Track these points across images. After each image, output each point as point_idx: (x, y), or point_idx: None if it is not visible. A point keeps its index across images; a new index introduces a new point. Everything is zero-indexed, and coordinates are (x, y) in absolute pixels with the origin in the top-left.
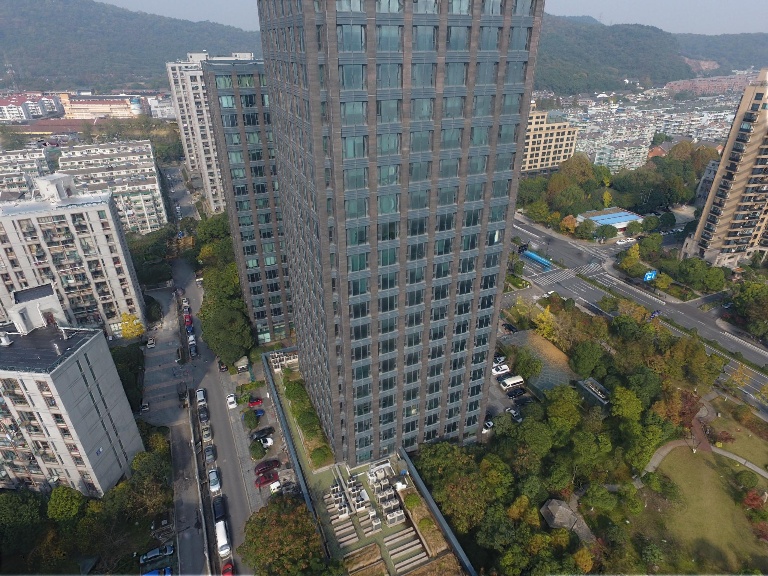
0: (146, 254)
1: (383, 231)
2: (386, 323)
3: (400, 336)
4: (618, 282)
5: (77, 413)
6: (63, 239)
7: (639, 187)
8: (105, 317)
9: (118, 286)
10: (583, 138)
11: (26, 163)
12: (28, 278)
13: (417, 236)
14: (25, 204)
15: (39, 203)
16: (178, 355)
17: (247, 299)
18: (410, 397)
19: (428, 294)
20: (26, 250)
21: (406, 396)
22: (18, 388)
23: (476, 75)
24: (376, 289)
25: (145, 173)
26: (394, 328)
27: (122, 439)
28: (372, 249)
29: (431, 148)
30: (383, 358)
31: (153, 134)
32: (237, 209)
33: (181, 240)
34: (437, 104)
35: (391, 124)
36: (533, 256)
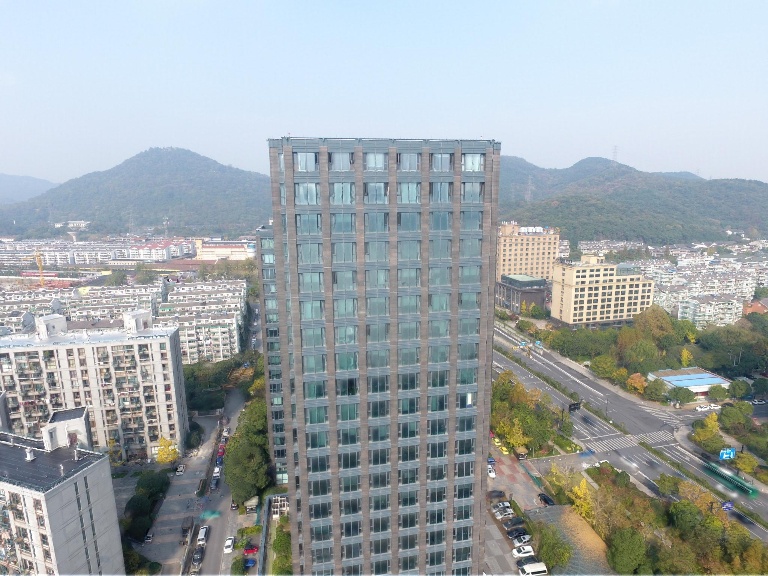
0: (210, 381)
1: (342, 386)
2: (348, 481)
3: (364, 497)
4: (692, 457)
5: (62, 536)
6: (128, 365)
7: (727, 346)
8: (148, 440)
9: (165, 411)
10: (664, 290)
11: (144, 296)
12: (93, 397)
13: (378, 393)
14: (109, 334)
15: (119, 333)
16: (199, 486)
17: (269, 436)
18: (379, 571)
19: (394, 454)
20: (97, 373)
21: (375, 569)
22: (21, 503)
23: (430, 250)
24: (335, 444)
25: (231, 308)
26: (357, 487)
27: (104, 571)
28: (330, 403)
29: (389, 312)
30: (345, 520)
31: (249, 275)
32: (268, 349)
33: (242, 371)
34: (391, 275)
35: (347, 291)
36: (591, 416)
